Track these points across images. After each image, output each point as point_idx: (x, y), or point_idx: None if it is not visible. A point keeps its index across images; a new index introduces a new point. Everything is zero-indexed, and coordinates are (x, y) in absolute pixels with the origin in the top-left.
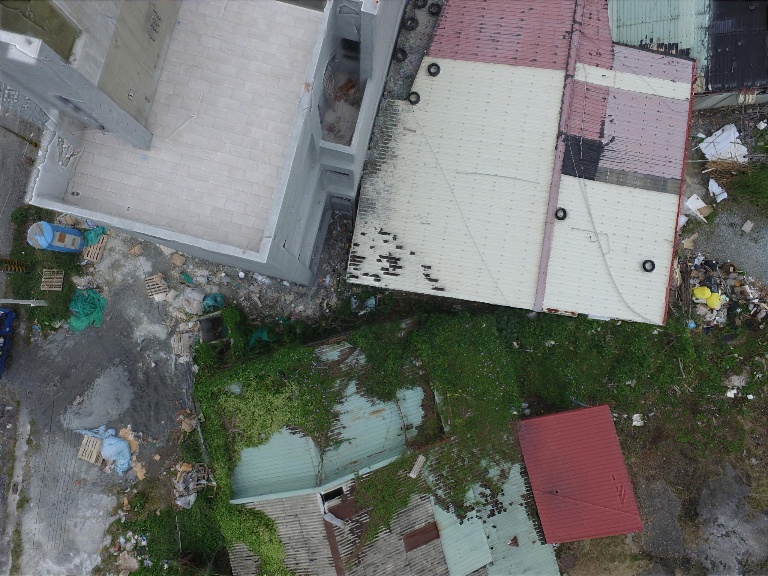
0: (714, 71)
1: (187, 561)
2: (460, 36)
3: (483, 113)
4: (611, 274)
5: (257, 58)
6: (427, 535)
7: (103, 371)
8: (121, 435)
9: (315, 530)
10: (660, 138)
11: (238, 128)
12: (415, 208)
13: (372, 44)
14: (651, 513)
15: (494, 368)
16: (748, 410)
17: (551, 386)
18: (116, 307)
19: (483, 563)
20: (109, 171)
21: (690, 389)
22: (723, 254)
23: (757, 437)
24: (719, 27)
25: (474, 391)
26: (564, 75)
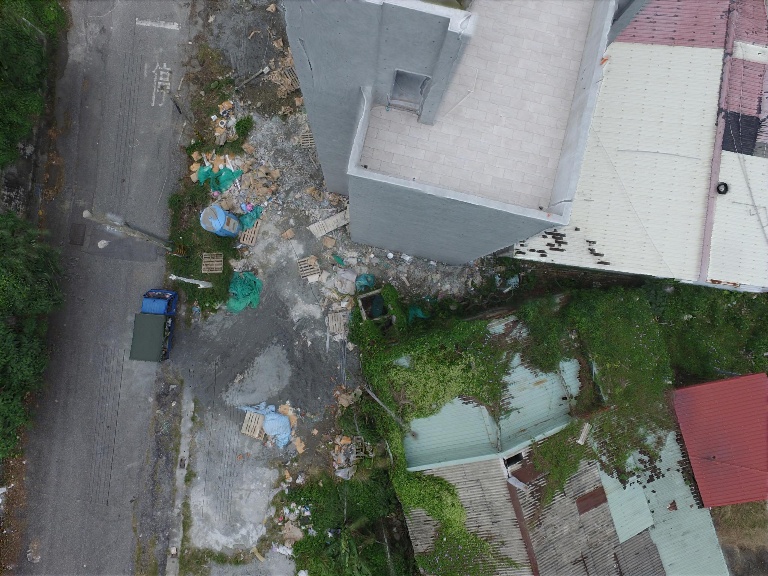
0: None
1: (353, 529)
2: None
3: (643, 92)
4: None
5: (528, 36)
6: (596, 499)
7: (262, 350)
8: (280, 411)
9: (498, 494)
10: None
11: (513, 102)
12: (578, 186)
13: None
14: None
15: (649, 340)
16: None
17: (693, 358)
18: (270, 288)
19: (646, 526)
20: (394, 145)
21: None
22: None
23: None
24: None
25: (631, 362)
26: (722, 54)
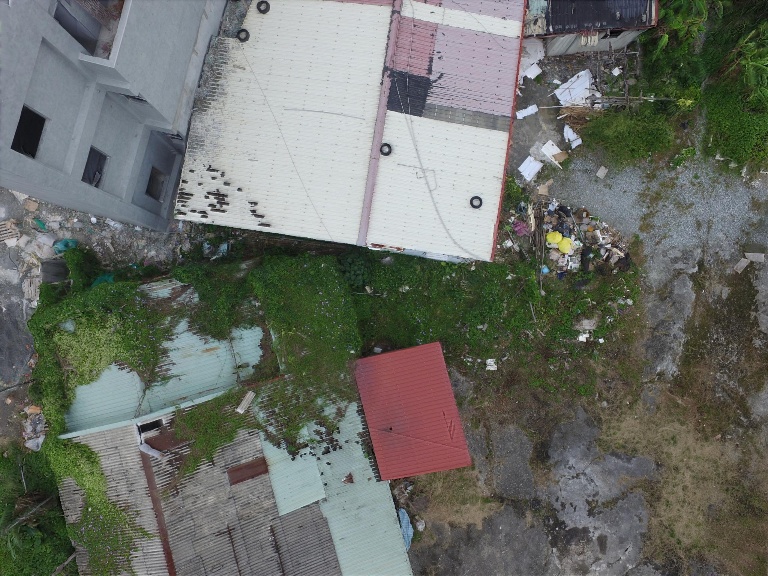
0: (555, 12)
1: (30, 501)
2: None
3: (311, 50)
4: (438, 210)
5: None
6: (254, 469)
7: None
8: None
9: (133, 461)
10: (490, 75)
11: None
12: (243, 145)
13: None
14: (503, 456)
15: (332, 307)
16: (600, 354)
17: (401, 329)
18: None
19: (315, 499)
20: None
21: (542, 333)
22: (578, 200)
23: (609, 381)
24: None
25: (310, 330)
26: (391, 11)
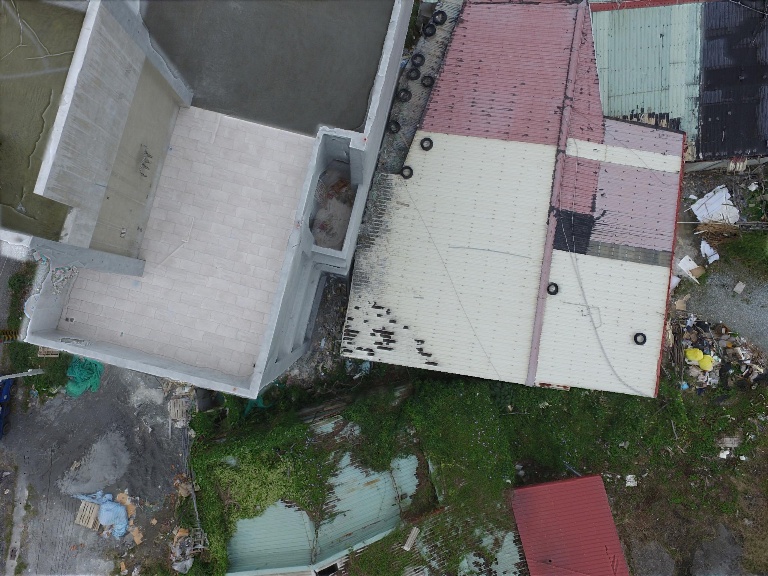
0: (705, 140)
1: None
2: (452, 110)
3: (475, 188)
4: (603, 347)
5: (248, 183)
6: None
7: (100, 436)
8: (118, 500)
9: None
10: (651, 211)
11: (229, 253)
12: (408, 282)
13: (361, 166)
14: (645, 574)
15: (487, 437)
16: (741, 471)
17: (545, 449)
18: (113, 372)
19: None
20: (102, 297)
21: (683, 450)
22: (715, 315)
23: (750, 497)
24: (709, 97)
25: (468, 460)
26: (555, 150)
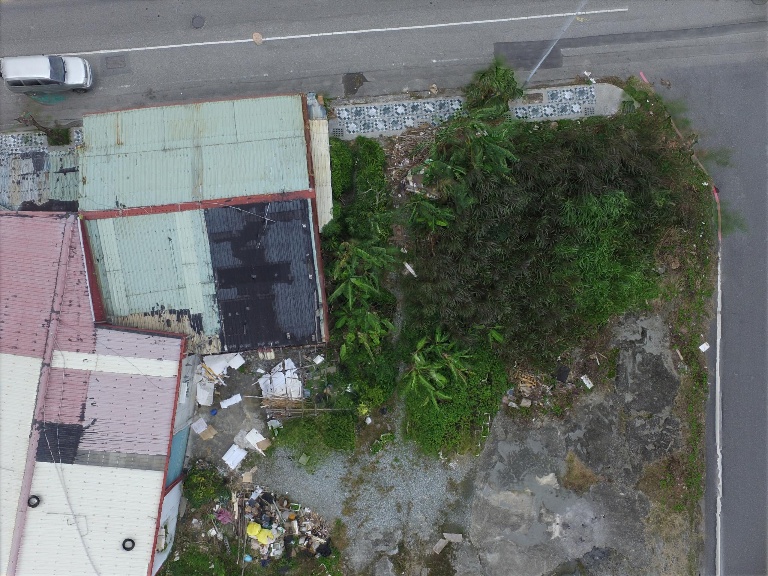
0: (228, 333)
1: None
2: None
3: None
4: (89, 555)
5: None
6: None
7: None
8: None
9: None
10: (145, 416)
11: None
12: None
13: None
14: None
15: None
16: None
17: None
18: None
19: None
20: None
21: None
22: (281, 486)
23: None
24: (227, 294)
25: None
26: (41, 364)
